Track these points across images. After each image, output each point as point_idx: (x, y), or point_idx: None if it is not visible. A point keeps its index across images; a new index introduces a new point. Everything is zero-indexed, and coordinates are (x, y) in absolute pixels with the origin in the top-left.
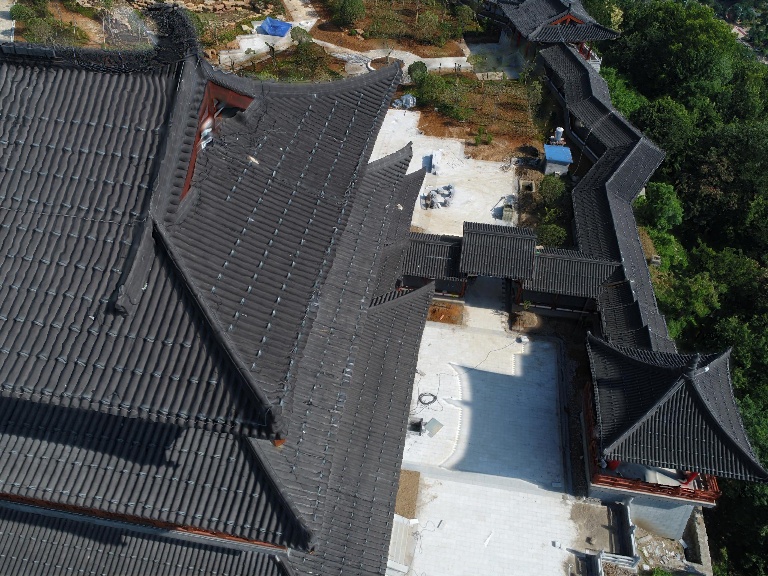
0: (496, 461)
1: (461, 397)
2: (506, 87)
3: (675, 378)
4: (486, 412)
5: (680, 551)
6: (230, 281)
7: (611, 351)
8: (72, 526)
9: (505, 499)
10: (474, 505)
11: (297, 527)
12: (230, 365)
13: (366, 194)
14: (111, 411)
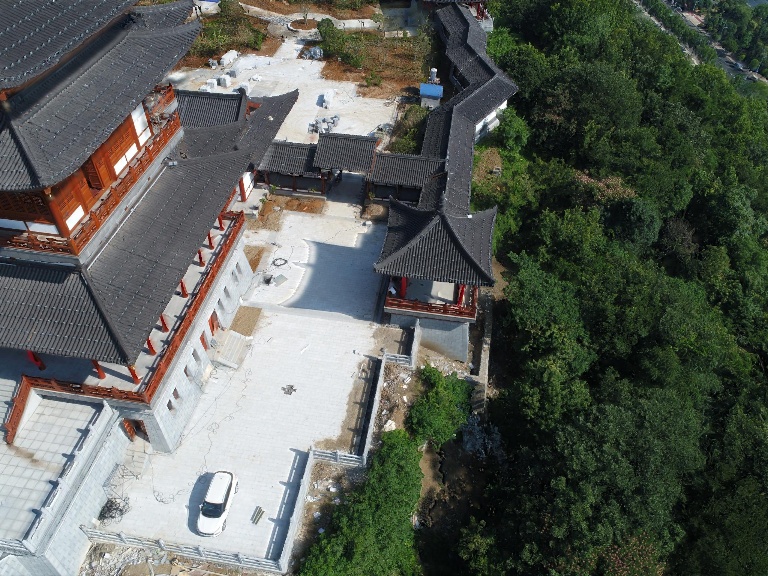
0: (324, 302)
1: (307, 261)
2: (406, 42)
3: None
4: (325, 271)
5: (467, 370)
6: (2, 41)
7: (403, 207)
8: None
9: (324, 325)
10: (299, 328)
11: None
12: None
13: (161, 49)
14: None
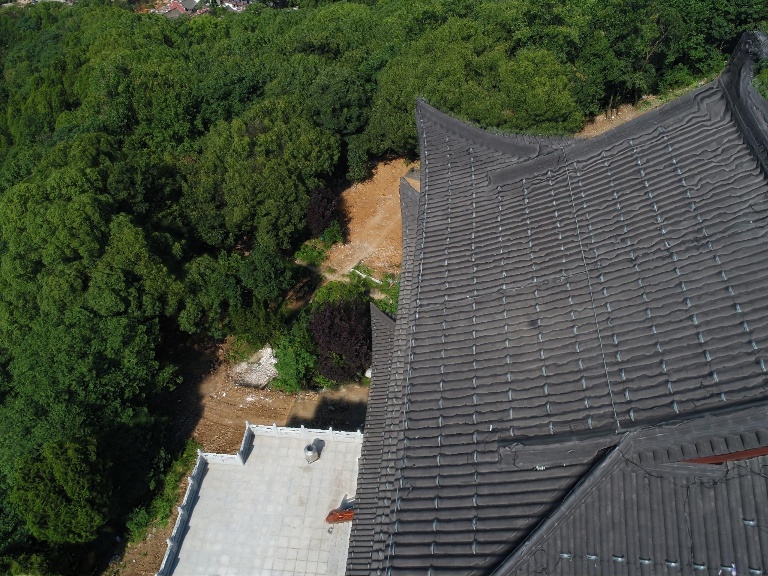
0: None
1: None
2: None
3: None
4: None
5: None
6: (593, 574)
7: None
8: None
9: None
10: None
11: None
12: None
13: None
14: (393, 492)
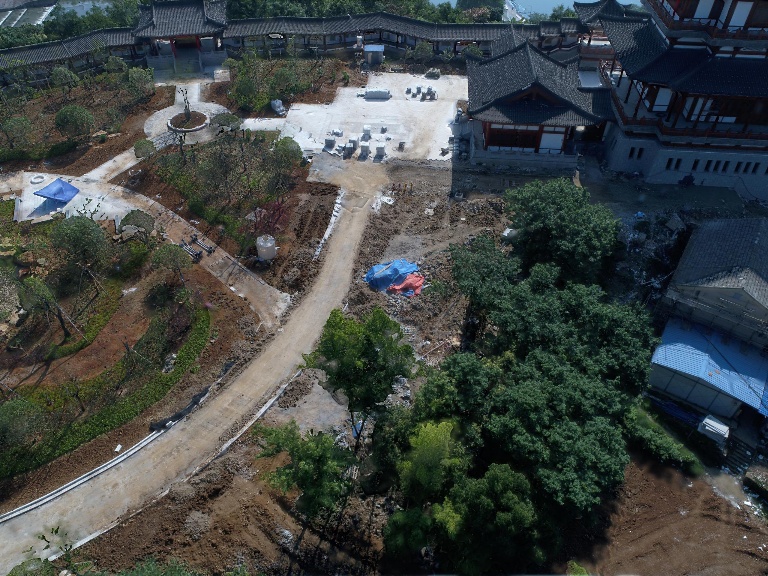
0: None
1: None
2: None
3: (611, 1)
4: None
5: None
6: None
7: None
8: None
9: None
10: None
11: None
12: None
13: None
14: None
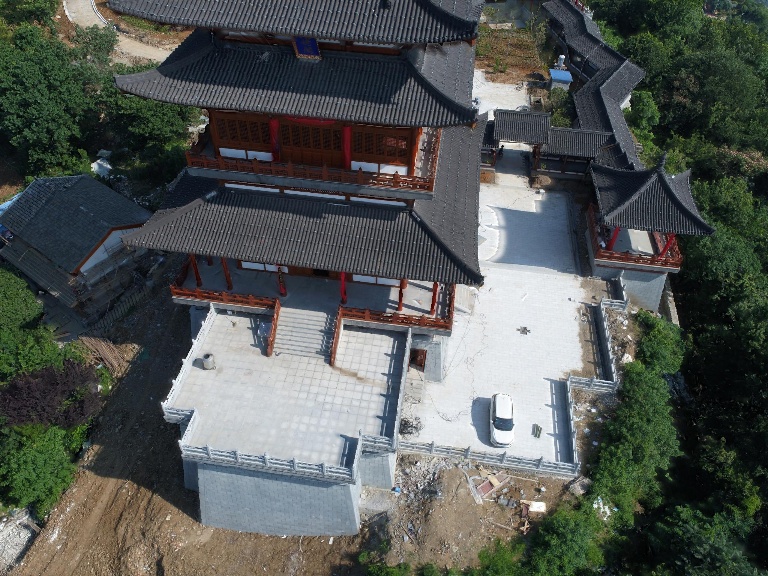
0: (526, 258)
1: (498, 224)
2: (515, 33)
3: (651, 175)
4: (517, 232)
5: None
6: None
7: (607, 170)
8: (292, 210)
9: (534, 277)
10: (513, 280)
11: (467, 113)
12: (447, 18)
13: None
14: (393, 40)
